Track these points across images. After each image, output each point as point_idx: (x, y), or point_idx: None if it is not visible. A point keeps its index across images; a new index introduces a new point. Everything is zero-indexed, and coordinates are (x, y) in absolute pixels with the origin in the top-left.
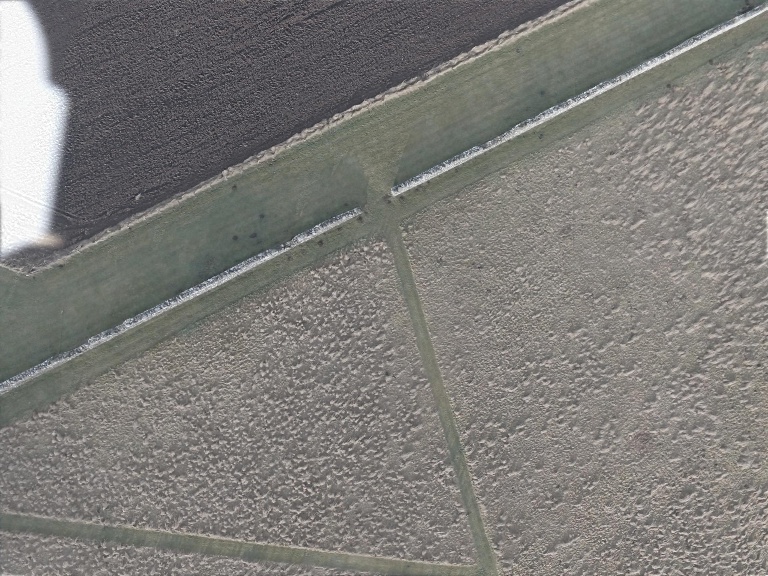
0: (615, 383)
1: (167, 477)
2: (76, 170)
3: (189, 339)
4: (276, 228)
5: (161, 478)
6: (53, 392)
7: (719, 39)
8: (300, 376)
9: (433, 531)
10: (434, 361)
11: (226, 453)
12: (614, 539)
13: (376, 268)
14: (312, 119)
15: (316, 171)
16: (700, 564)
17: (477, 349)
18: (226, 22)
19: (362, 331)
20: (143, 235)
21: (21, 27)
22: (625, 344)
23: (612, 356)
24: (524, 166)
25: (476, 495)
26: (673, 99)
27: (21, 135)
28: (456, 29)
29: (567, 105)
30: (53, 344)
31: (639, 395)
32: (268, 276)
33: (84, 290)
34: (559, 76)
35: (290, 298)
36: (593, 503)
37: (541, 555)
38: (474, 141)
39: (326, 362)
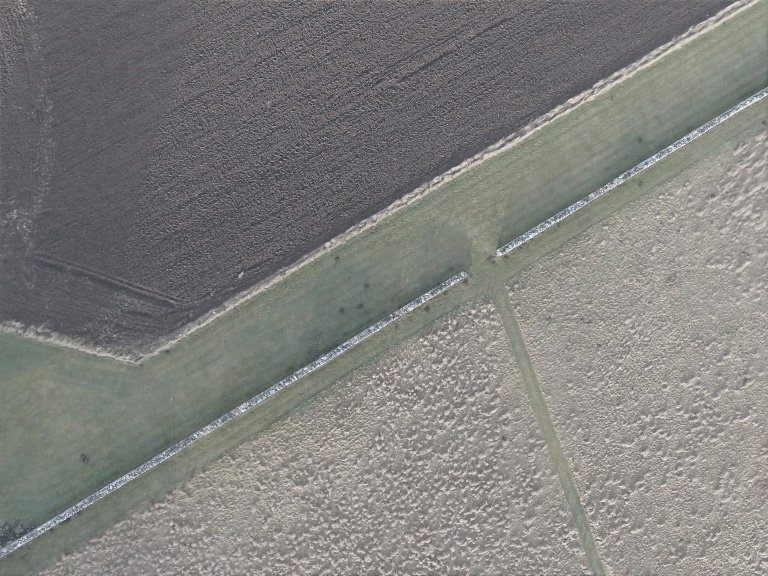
0: (731, 430)
1: (289, 560)
2: (177, 252)
3: (302, 417)
4: (382, 297)
5: (283, 562)
6: (168, 481)
7: None
8: (416, 447)
9: None
10: (549, 421)
11: (347, 531)
12: None
13: (485, 331)
14: (411, 183)
15: (418, 236)
16: None
17: (591, 406)
18: (318, 90)
19: (476, 396)
20: (248, 314)
21: (111, 109)
22: (739, 390)
23: (727, 403)
24: (626, 215)
25: (600, 556)
26: None
27: (118, 220)
28: (550, 81)
29: (668, 152)
30: (166, 432)
31: (756, 440)
32: (377, 347)
33: (193, 374)
34: (655, 121)
35: (400, 368)
36: (717, 554)
37: None
38: (575, 194)
39: (441, 431)
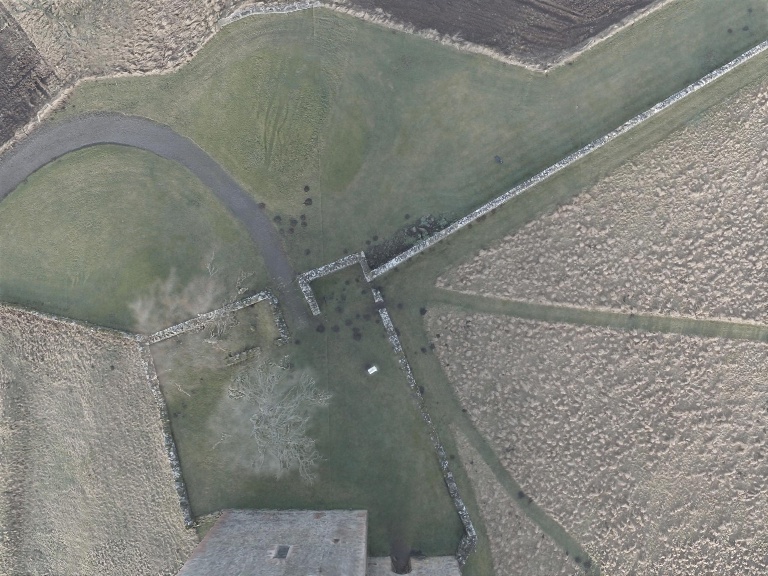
0: None
1: (685, 265)
2: None
3: (697, 129)
4: (765, 21)
5: (681, 265)
6: (573, 186)
7: None
8: None
9: None
10: None
11: (738, 239)
12: None
13: None
14: None
15: None
16: None
17: None
18: None
19: None
20: (644, 31)
21: None
22: None
23: None
24: None
25: None
26: None
27: None
28: None
29: None
30: (573, 137)
31: None
32: (759, 68)
33: (595, 85)
34: None
35: None
36: None
37: None
38: None
39: None
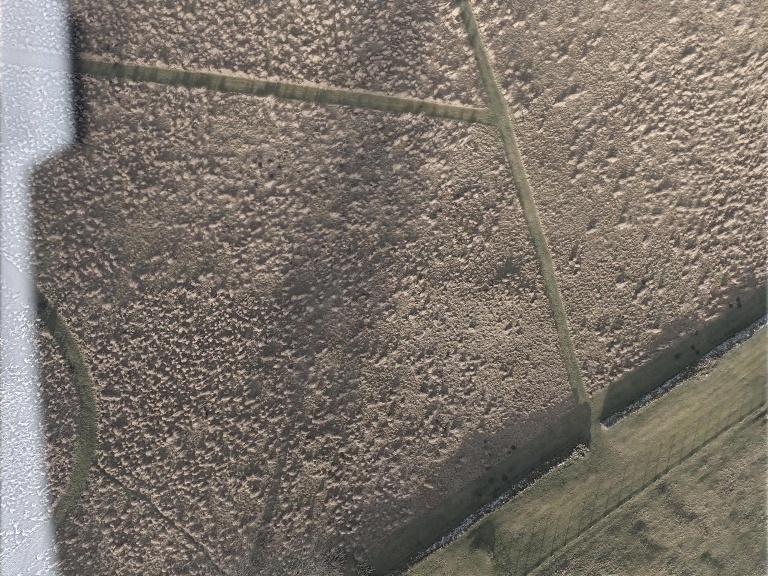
0: None
1: (176, 16)
2: None
3: None
4: None
5: (170, 16)
6: None
7: None
8: None
9: (443, 72)
10: None
11: None
12: (620, 96)
13: None
14: None
15: None
16: (704, 124)
17: None
18: None
19: None
20: None
21: None
22: None
23: None
24: None
25: (483, 43)
26: None
27: None
28: None
29: None
30: None
31: None
32: None
33: None
34: None
35: None
36: (598, 59)
37: (550, 106)
38: None
39: None
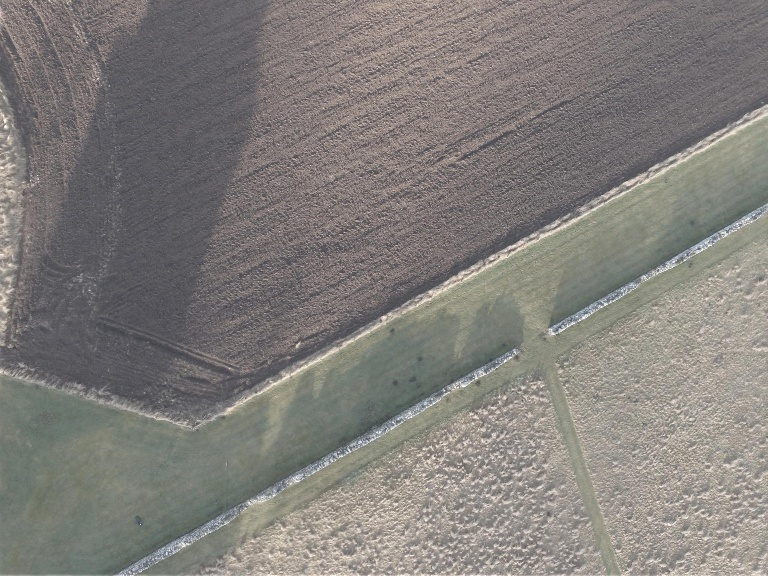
0: None
1: None
2: (236, 320)
3: (353, 487)
4: (435, 371)
5: None
6: (219, 545)
7: None
8: (463, 520)
9: None
10: (594, 498)
11: None
12: None
13: (534, 407)
14: (468, 260)
15: (472, 311)
16: None
17: (635, 484)
18: (380, 166)
19: (523, 472)
20: (304, 383)
21: (178, 178)
22: None
23: (767, 485)
24: (675, 296)
25: None
26: None
27: (181, 286)
28: (607, 164)
29: (721, 237)
30: (219, 498)
31: None
32: (427, 419)
33: (247, 441)
34: (707, 205)
35: (450, 440)
36: None
37: None
38: (627, 275)
39: (488, 505)
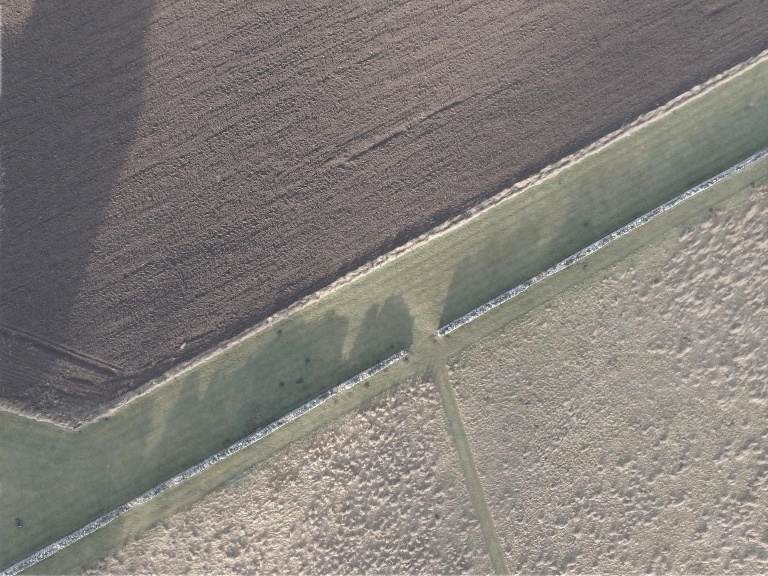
0: (665, 514)
1: None
2: (120, 321)
3: (237, 489)
4: (322, 372)
5: None
6: (101, 548)
7: (760, 162)
8: (349, 523)
9: None
10: (483, 501)
11: None
12: None
13: (423, 409)
14: (356, 261)
15: (361, 313)
16: None
17: (526, 487)
18: (268, 166)
19: (411, 474)
20: (189, 384)
21: (63, 178)
22: (675, 475)
23: (662, 487)
24: (569, 298)
25: None
26: (716, 224)
27: (64, 287)
28: (498, 165)
29: (612, 239)
30: (101, 500)
31: (690, 525)
32: (315, 421)
33: (131, 443)
34: (602, 206)
35: (337, 442)
36: None
37: None
38: (519, 277)
39: (375, 507)
